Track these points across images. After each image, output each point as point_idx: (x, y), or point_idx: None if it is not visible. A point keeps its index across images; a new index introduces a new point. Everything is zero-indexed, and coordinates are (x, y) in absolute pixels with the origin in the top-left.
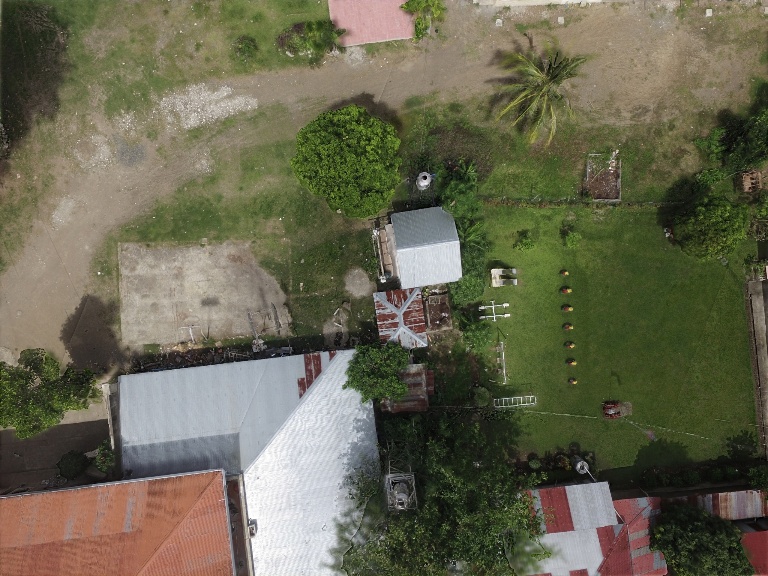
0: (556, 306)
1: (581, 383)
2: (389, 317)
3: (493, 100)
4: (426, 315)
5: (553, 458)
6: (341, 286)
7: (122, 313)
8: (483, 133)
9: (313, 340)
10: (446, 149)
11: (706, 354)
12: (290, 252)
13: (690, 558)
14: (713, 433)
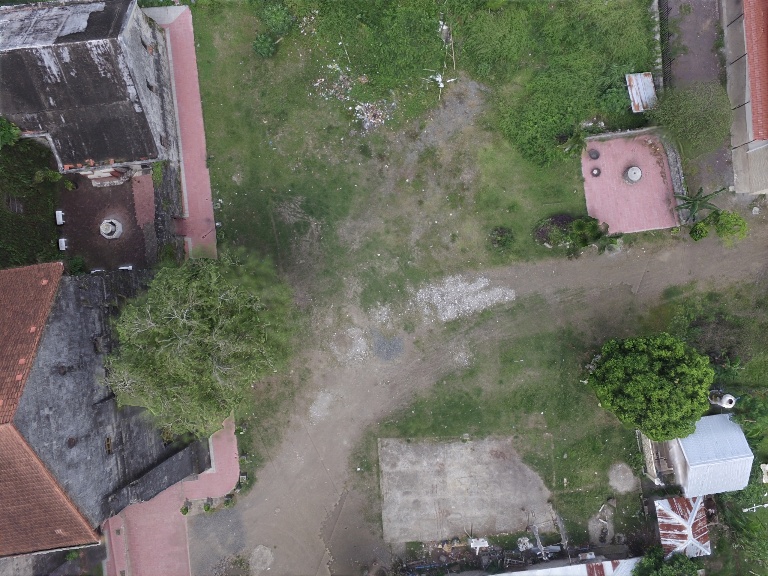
0: None
1: None
2: (675, 528)
3: (750, 288)
4: None
5: None
6: (605, 481)
7: (383, 510)
8: (742, 323)
9: (578, 537)
10: (708, 341)
11: None
12: (552, 447)
13: None
14: None
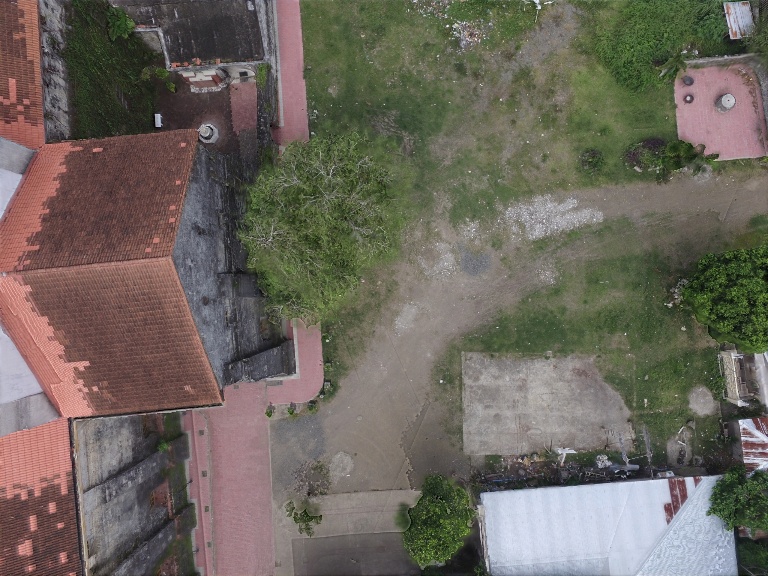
0: None
1: None
2: (759, 446)
3: None
4: None
5: None
6: (685, 404)
7: (464, 423)
8: None
9: (657, 458)
10: None
11: None
12: (634, 368)
13: None
14: None
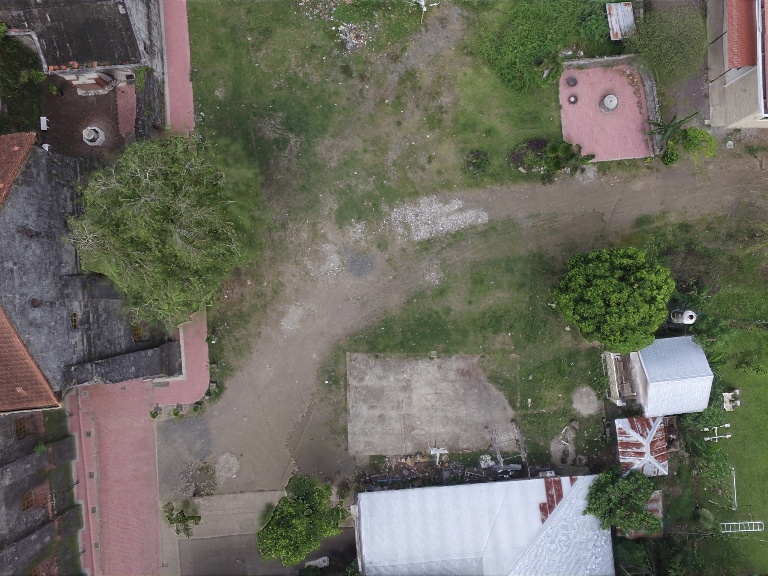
0: None
1: None
2: (634, 446)
3: (722, 221)
4: None
5: None
6: (569, 404)
7: (349, 423)
8: (712, 254)
9: (540, 457)
10: (676, 270)
11: None
12: (518, 368)
13: None
14: None
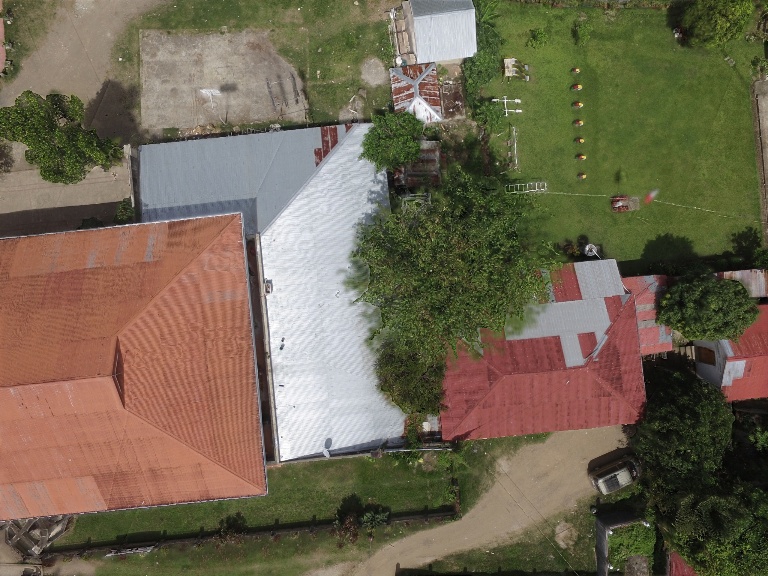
0: (567, 103)
1: (590, 179)
2: (405, 89)
3: None
4: (440, 103)
5: (562, 249)
6: (357, 75)
7: (142, 98)
8: None
9: None
10: None
11: (713, 152)
12: (308, 41)
13: (696, 308)
14: (718, 229)
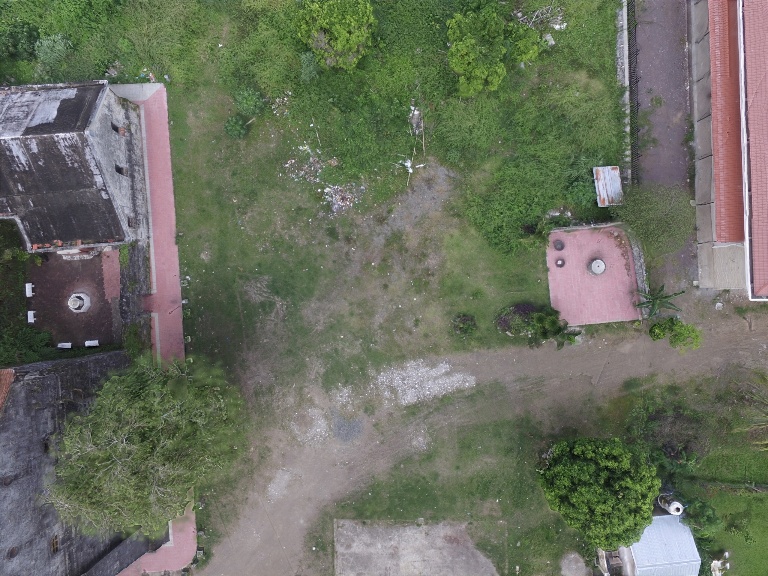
0: None
1: None
2: None
3: (711, 383)
4: None
5: None
6: (557, 571)
7: None
8: (701, 417)
9: None
10: (665, 435)
11: None
12: (506, 534)
13: None
14: None
